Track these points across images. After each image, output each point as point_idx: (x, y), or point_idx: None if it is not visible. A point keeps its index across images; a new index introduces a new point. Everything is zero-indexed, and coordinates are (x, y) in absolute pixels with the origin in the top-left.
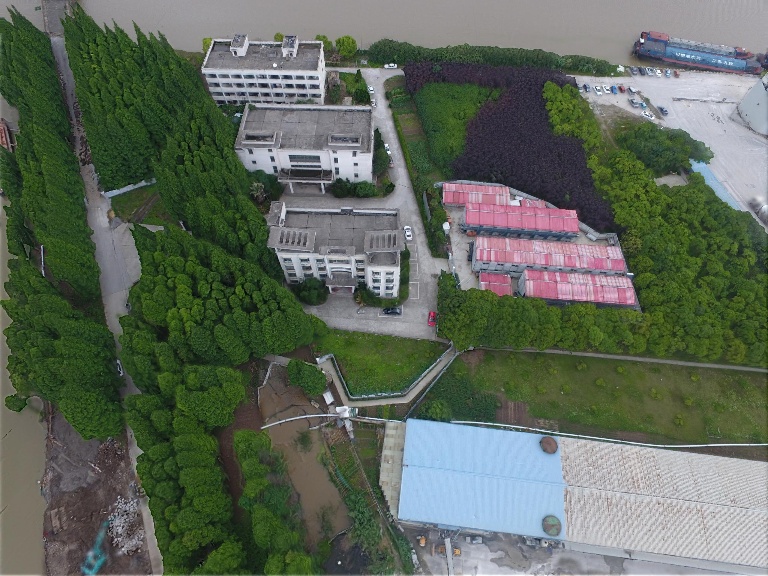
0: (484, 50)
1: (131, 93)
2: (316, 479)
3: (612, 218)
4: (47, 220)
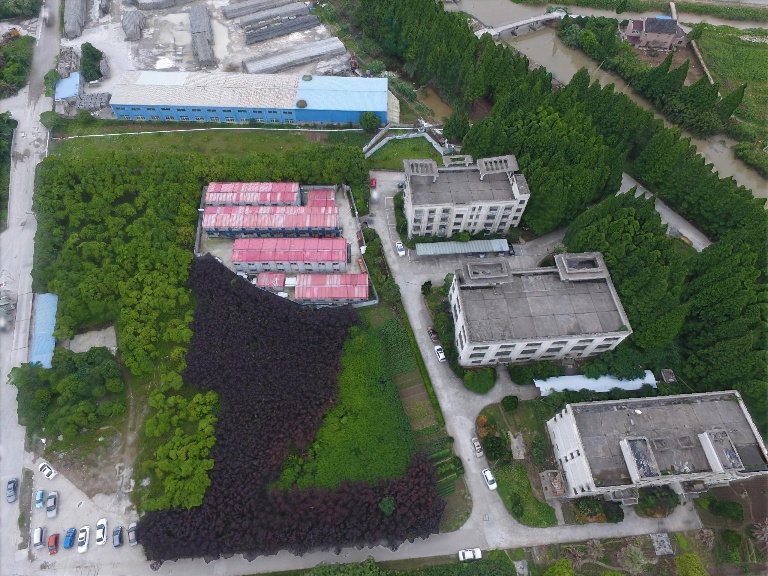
0: None
1: None
2: (435, 108)
3: (195, 260)
4: (701, 159)
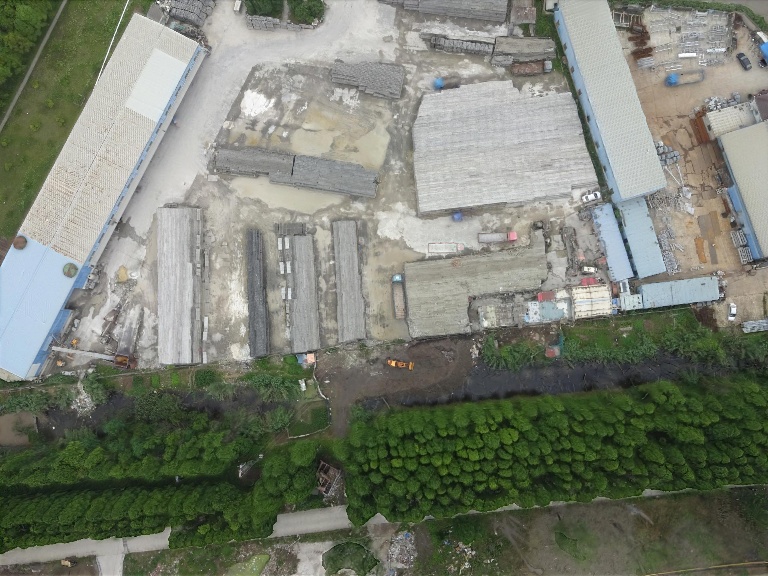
0: None
1: None
2: None
3: None
4: None
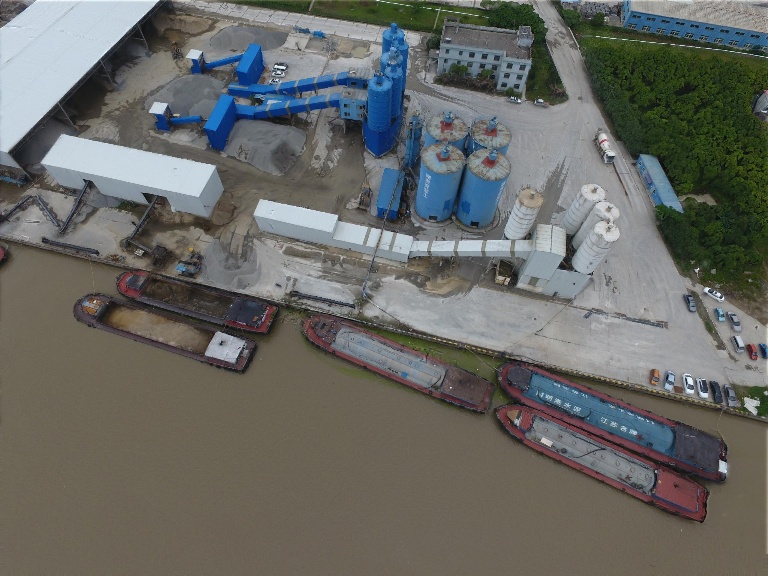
0: None
1: None
2: None
3: None
4: None
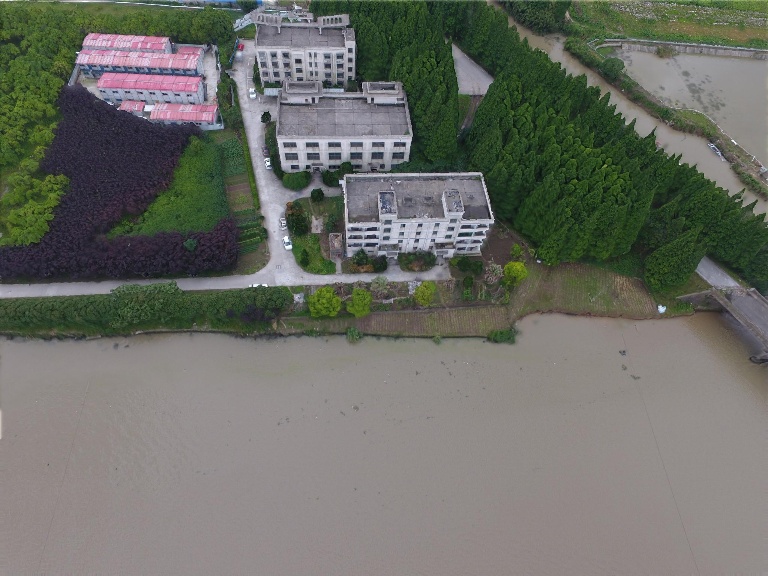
0: (104, 298)
1: (523, 115)
2: None
3: (65, 85)
4: (505, 25)
